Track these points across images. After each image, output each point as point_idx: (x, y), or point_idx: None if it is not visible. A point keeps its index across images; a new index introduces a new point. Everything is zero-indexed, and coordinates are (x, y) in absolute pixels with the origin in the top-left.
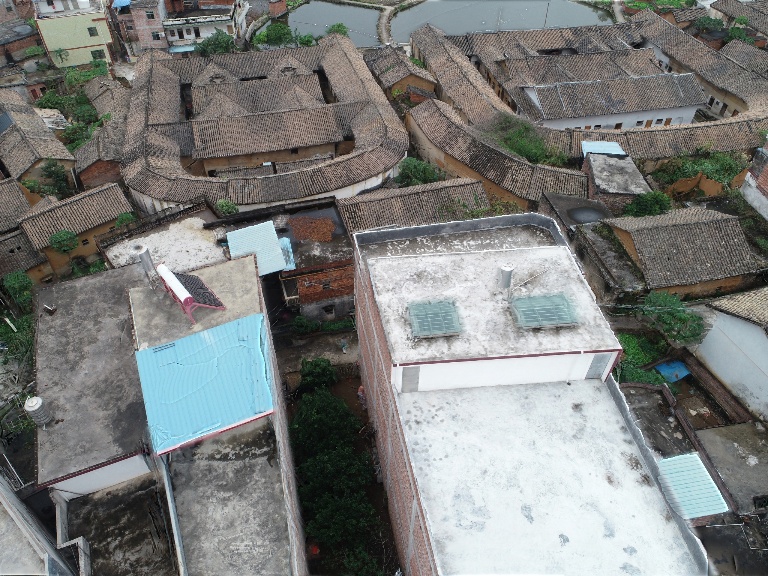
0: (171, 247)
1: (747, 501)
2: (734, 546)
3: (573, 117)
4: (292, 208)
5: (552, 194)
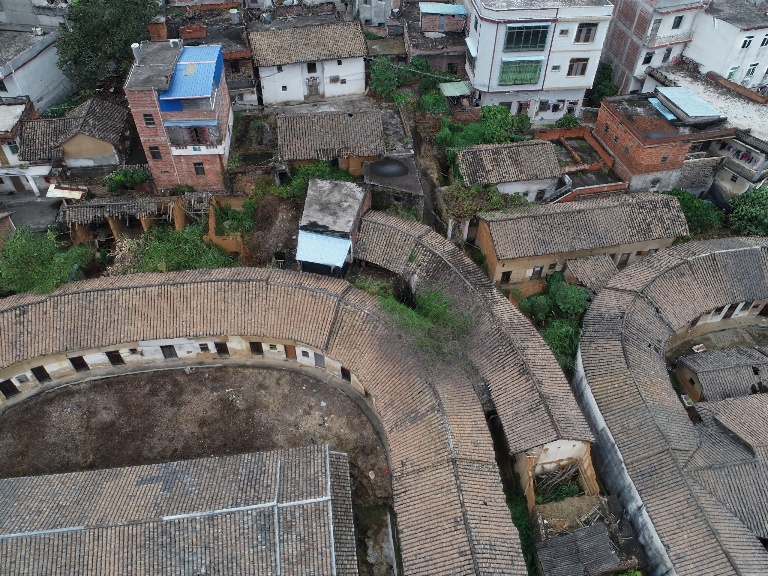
0: (762, 120)
1: (388, 39)
2: (411, 19)
3: (268, 452)
4: (682, 140)
5: (415, 191)
